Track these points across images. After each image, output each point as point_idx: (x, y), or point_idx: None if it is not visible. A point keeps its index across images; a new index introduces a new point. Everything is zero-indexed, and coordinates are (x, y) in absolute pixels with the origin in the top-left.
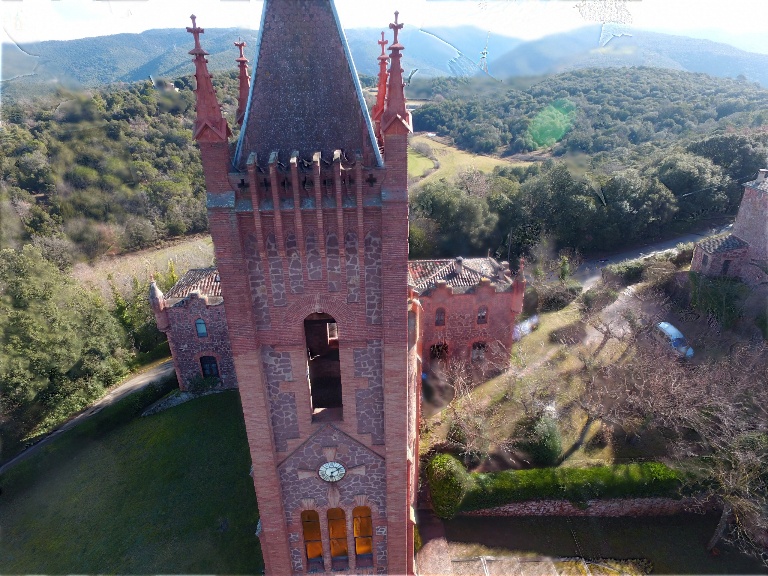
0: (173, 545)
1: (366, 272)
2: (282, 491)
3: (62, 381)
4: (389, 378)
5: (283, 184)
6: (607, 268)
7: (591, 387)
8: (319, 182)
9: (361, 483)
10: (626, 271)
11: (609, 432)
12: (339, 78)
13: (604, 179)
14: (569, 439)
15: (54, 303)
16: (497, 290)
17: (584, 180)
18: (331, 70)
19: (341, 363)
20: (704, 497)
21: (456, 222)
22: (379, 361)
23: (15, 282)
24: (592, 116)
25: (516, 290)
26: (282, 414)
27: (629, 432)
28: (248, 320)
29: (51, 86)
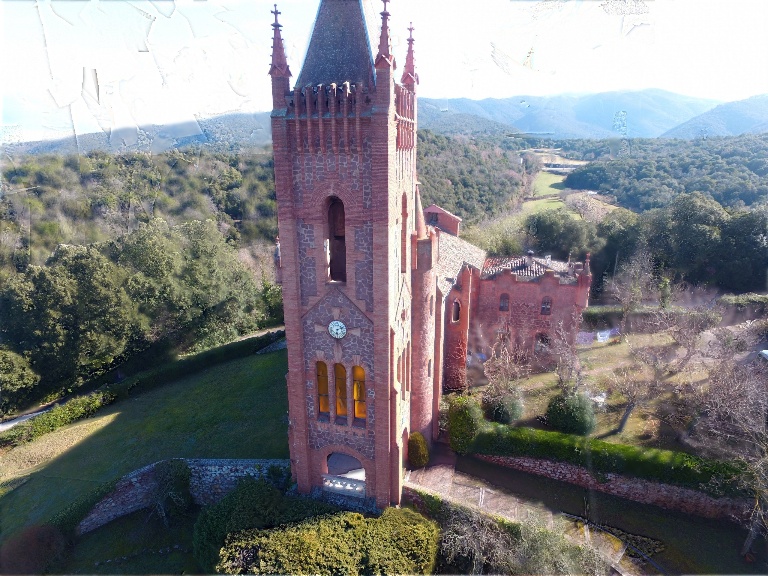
0: (248, 425)
1: (364, 167)
2: (304, 340)
3: (211, 318)
4: (376, 250)
5: (315, 103)
6: (722, 298)
7: (655, 392)
8: (333, 100)
9: (358, 344)
10: (746, 304)
11: (654, 425)
12: (358, 40)
13: (742, 213)
14: (609, 426)
15: (216, 260)
16: (561, 282)
17: (618, 158)
18: (354, 35)
19: (346, 237)
20: (725, 479)
21: (558, 241)
22: (371, 239)
23: (196, 241)
24: (697, 132)
25: (580, 284)
26: (307, 275)
27: (676, 428)
28: (288, 195)
29: (249, 119)
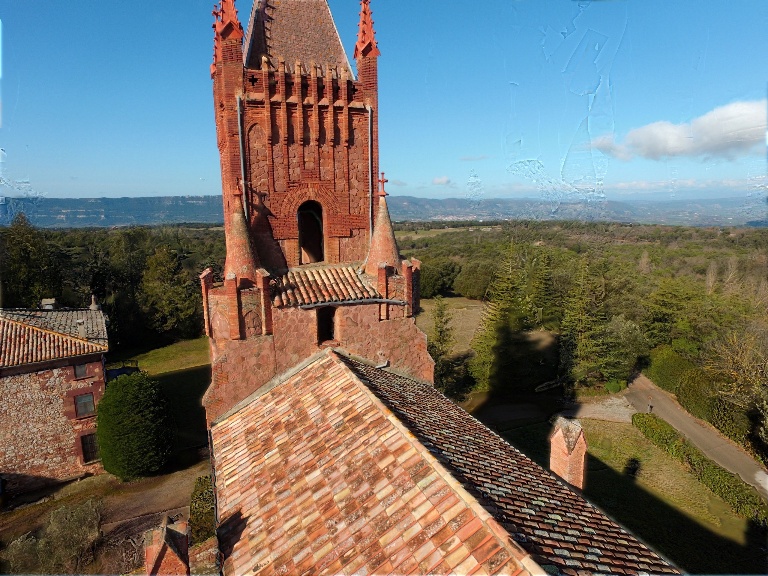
0: None
1: None
2: None
3: None
4: None
5: None
6: None
7: None
8: None
9: None
10: None
11: None
12: None
13: None
14: None
15: None
16: None
17: None
18: None
19: None
20: None
21: None
22: None
23: None
24: None
25: None
26: None
27: None
28: None
29: None
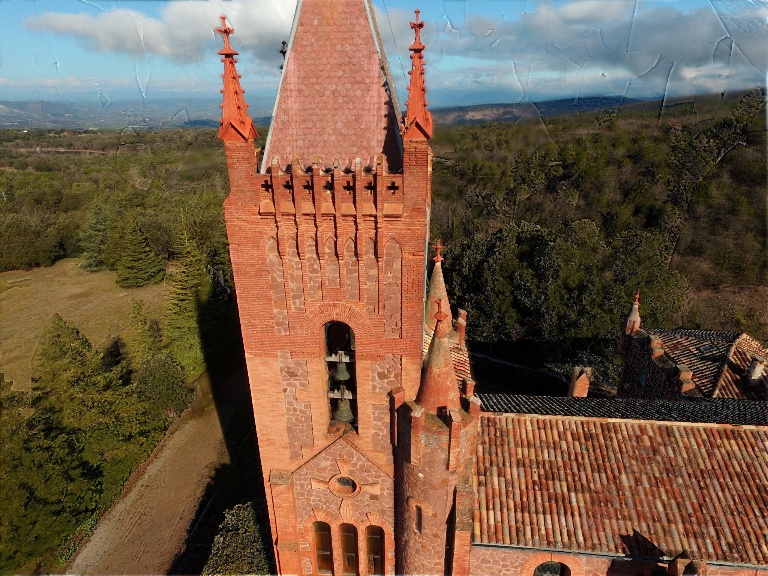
0: None
1: None
2: None
3: None
4: None
5: None
6: None
7: None
8: None
9: None
10: None
11: None
12: None
13: None
14: None
15: None
16: None
17: None
18: None
19: None
20: None
21: None
22: None
23: None
24: None
25: None
26: None
27: None
28: None
29: None
